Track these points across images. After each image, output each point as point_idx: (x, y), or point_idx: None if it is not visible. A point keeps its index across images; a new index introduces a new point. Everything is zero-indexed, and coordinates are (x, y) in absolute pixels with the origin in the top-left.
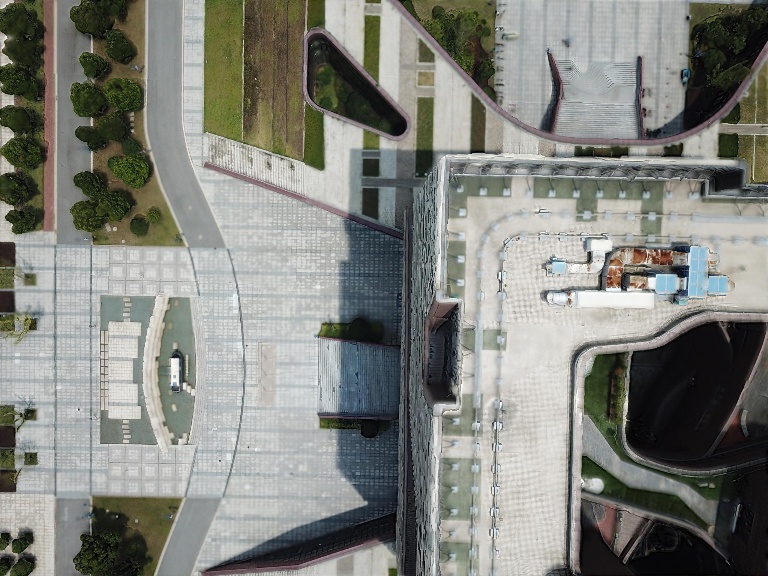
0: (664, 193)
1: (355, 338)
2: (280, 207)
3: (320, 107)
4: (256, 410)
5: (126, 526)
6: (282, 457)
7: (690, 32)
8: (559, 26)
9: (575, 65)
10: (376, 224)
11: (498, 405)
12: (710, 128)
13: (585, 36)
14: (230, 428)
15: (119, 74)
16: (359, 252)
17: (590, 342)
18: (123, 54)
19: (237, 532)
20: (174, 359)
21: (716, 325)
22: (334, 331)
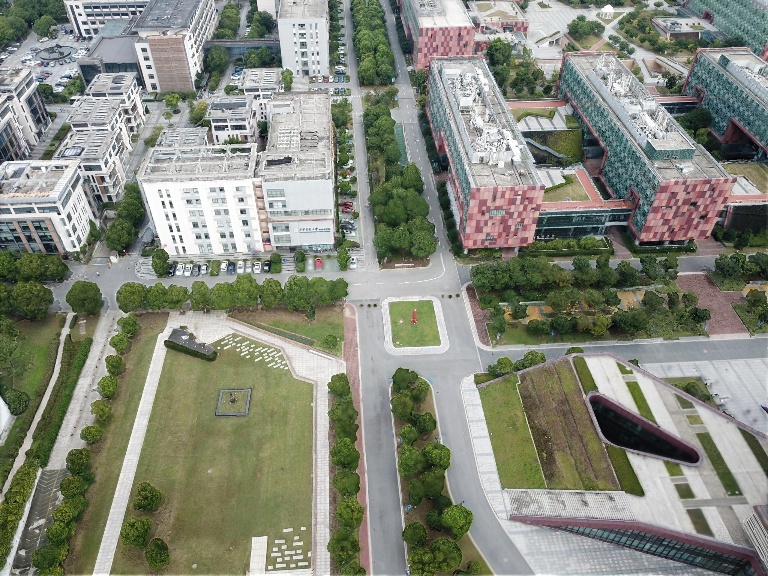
0: None
1: None
2: (593, 552)
3: (619, 446)
4: None
5: None
6: None
7: None
8: (759, 390)
9: None
10: (715, 542)
11: None
12: None
13: None
14: None
15: (420, 448)
16: None
17: None
18: None
19: None
20: None
21: None
22: None
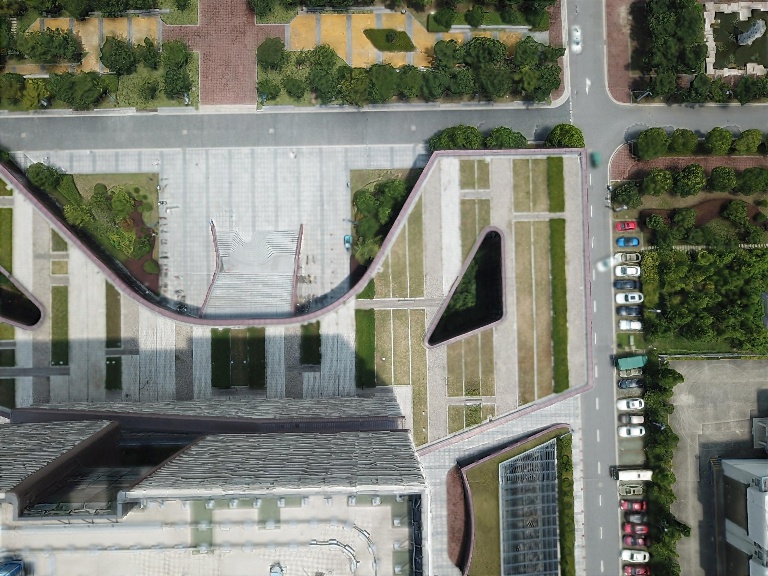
0: None
1: None
2: None
3: None
4: None
5: None
6: None
7: (351, 198)
8: (222, 197)
9: (239, 235)
10: None
11: None
12: (346, 304)
13: (248, 206)
14: None
15: None
16: None
17: None
18: None
19: None
20: None
21: None
22: None
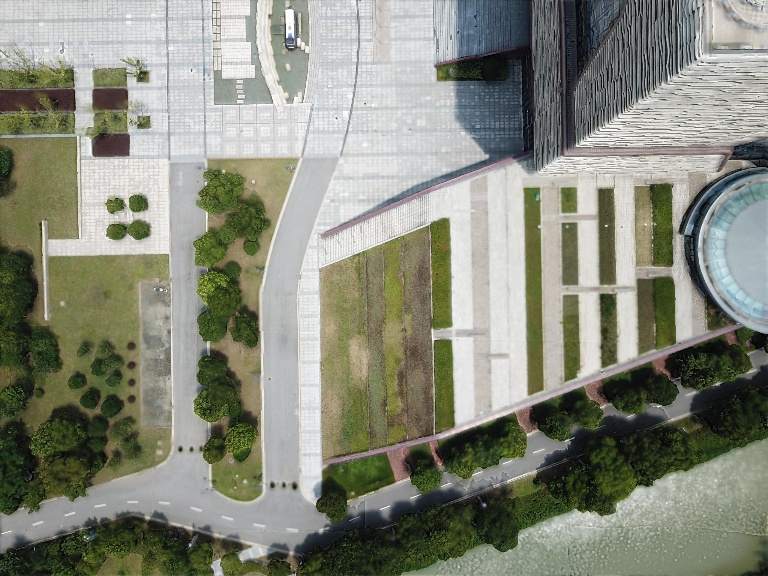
0: None
1: None
2: None
3: None
4: (372, 65)
5: (243, 187)
6: (400, 113)
7: None
8: None
9: None
10: None
11: None
12: None
13: None
14: (346, 85)
15: None
16: None
17: None
18: None
19: (356, 192)
20: (289, 10)
21: None
22: None
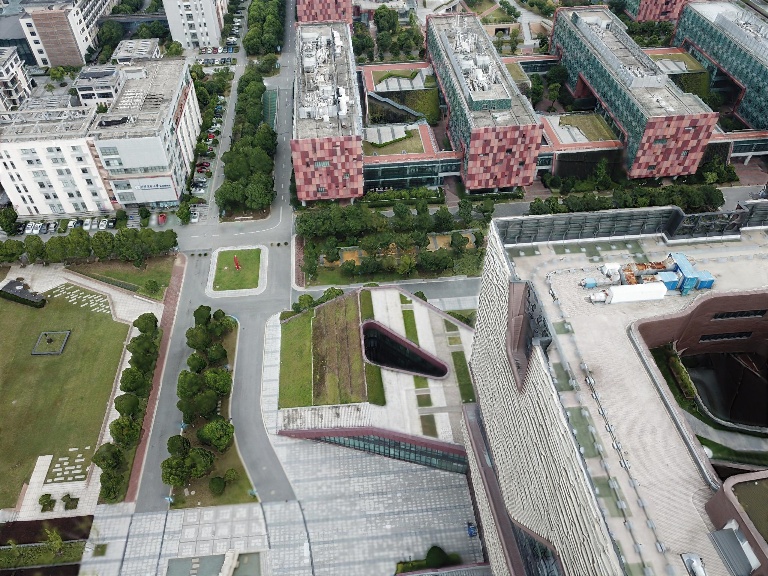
0: (640, 245)
1: (435, 566)
2: (346, 459)
3: None
4: None
5: None
6: None
7: None
8: None
9: None
10: (437, 441)
11: (584, 365)
12: None
13: None
14: None
15: None
16: (423, 489)
17: None
18: (221, 356)
19: None
20: None
21: (742, 369)
22: (411, 566)
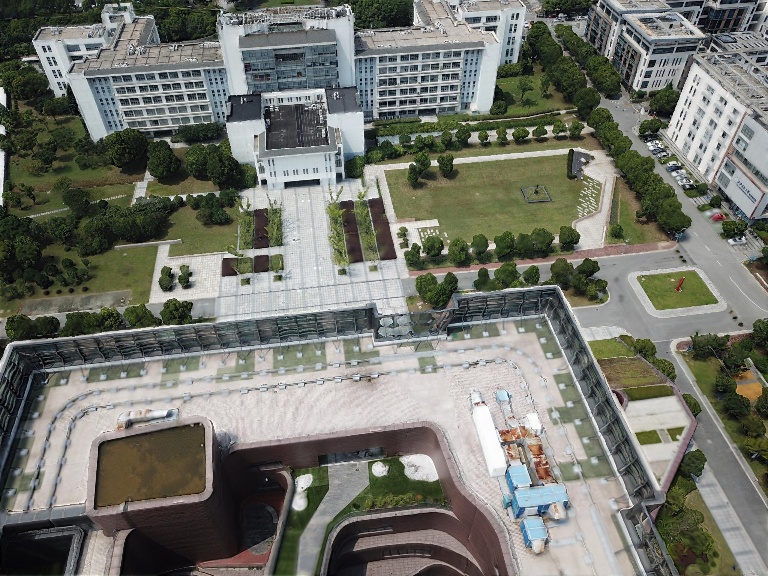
0: (603, 476)
1: None
2: None
3: None
4: None
5: None
6: None
7: None
8: None
9: None
10: None
11: (375, 373)
12: None
13: None
14: None
15: None
16: None
17: (445, 435)
18: None
19: None
20: None
21: None
22: None
